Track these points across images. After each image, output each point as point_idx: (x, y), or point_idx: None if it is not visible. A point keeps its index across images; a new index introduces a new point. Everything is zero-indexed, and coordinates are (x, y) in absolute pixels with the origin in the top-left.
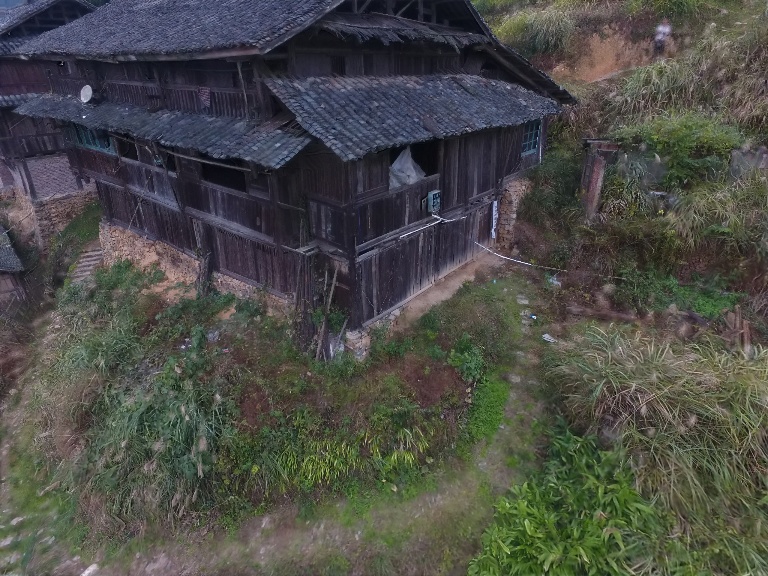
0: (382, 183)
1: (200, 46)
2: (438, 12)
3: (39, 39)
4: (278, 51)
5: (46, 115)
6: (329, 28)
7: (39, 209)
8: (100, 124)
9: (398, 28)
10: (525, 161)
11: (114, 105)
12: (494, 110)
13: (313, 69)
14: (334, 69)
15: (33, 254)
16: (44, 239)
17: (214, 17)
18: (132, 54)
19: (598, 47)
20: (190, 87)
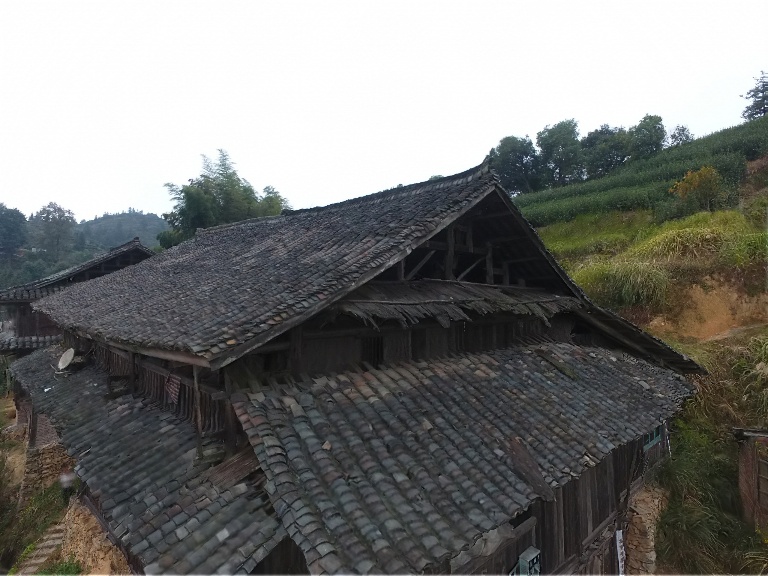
0: (437, 569)
1: (145, 338)
2: (511, 271)
3: (60, 292)
4: (273, 341)
5: (21, 379)
6: (353, 312)
7: (32, 459)
8: (48, 407)
9: (462, 300)
10: (649, 457)
11: (90, 375)
12: (612, 406)
13: (331, 359)
14: (366, 355)
15: (8, 514)
16: (24, 497)
17: (213, 284)
18: (86, 331)
19: (703, 299)
20: (162, 371)
